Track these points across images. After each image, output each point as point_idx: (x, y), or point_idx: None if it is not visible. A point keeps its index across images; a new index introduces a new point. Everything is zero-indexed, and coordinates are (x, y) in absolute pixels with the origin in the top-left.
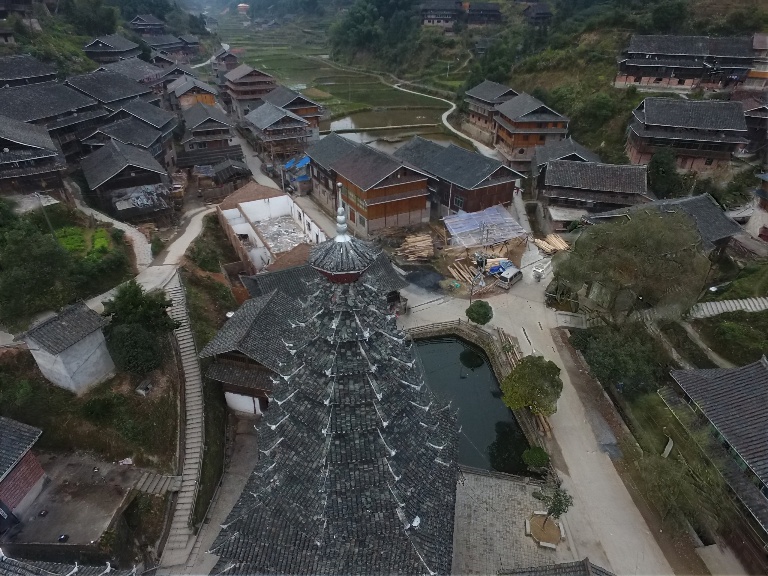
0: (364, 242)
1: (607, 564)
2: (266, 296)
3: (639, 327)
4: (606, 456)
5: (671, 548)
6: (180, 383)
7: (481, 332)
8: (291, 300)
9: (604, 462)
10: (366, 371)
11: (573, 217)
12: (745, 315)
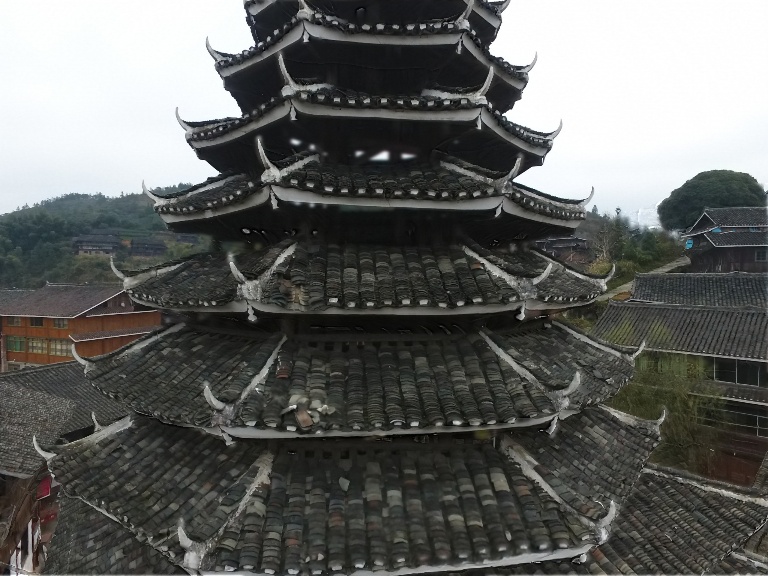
0: None
1: None
2: None
3: None
4: None
5: None
6: None
7: None
8: None
9: None
10: (495, 8)
11: None
12: None
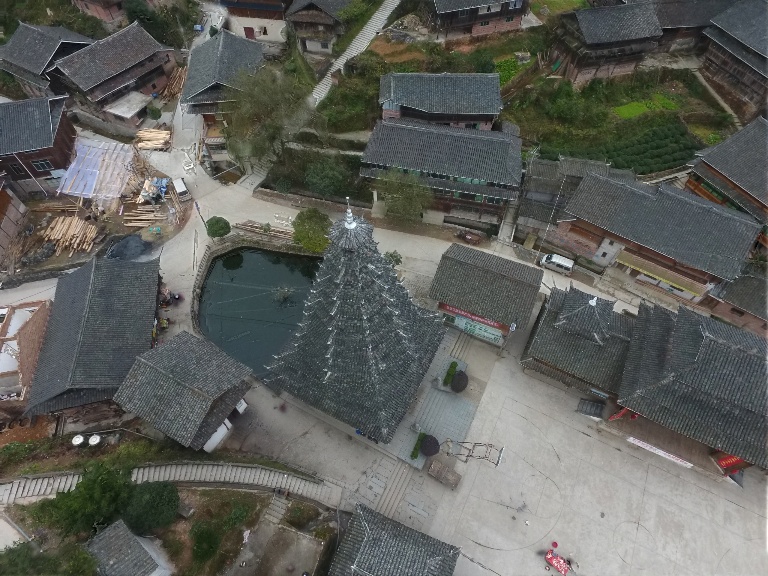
0: None
1: (417, 260)
2: (135, 372)
3: (290, 151)
4: None
5: (418, 231)
6: None
7: (231, 238)
8: (156, 350)
9: None
10: None
11: (137, 105)
12: (326, 102)
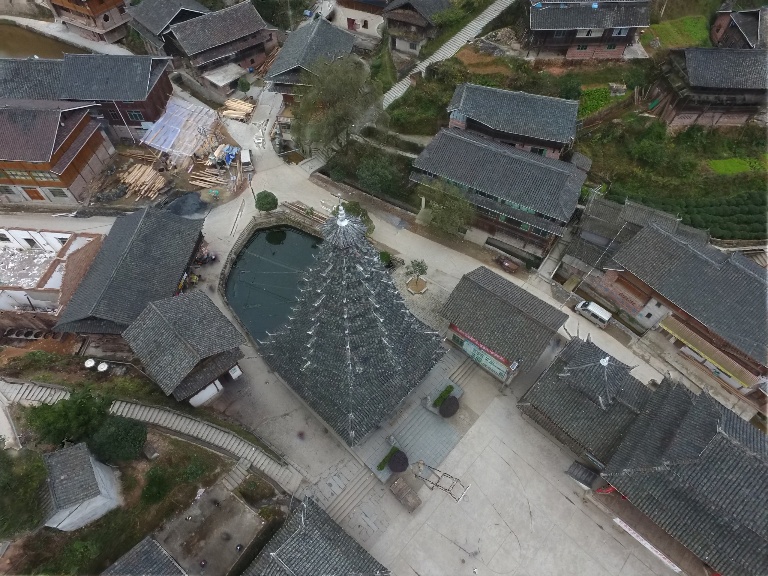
0: (345, 215)
1: (446, 275)
2: (145, 315)
3: None
4: (404, 230)
5: (457, 246)
6: (153, 429)
7: (276, 214)
8: (169, 300)
9: (406, 233)
10: None
11: (231, 75)
12: (400, 101)
